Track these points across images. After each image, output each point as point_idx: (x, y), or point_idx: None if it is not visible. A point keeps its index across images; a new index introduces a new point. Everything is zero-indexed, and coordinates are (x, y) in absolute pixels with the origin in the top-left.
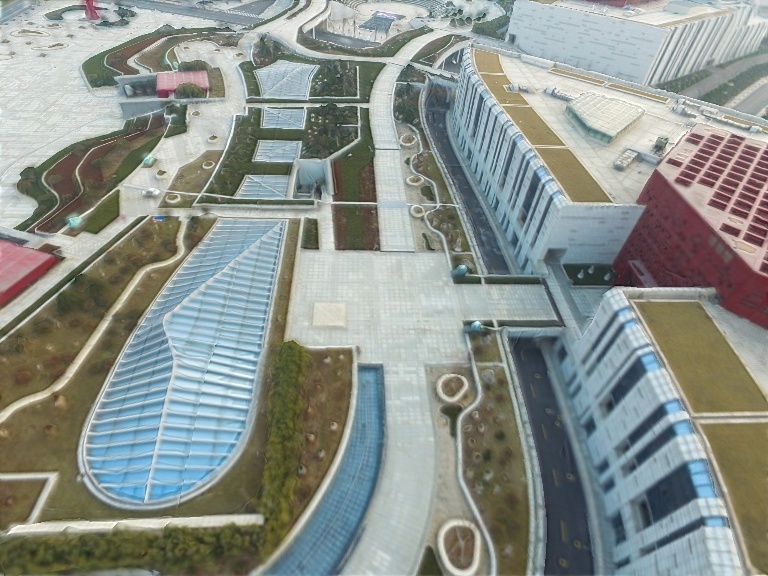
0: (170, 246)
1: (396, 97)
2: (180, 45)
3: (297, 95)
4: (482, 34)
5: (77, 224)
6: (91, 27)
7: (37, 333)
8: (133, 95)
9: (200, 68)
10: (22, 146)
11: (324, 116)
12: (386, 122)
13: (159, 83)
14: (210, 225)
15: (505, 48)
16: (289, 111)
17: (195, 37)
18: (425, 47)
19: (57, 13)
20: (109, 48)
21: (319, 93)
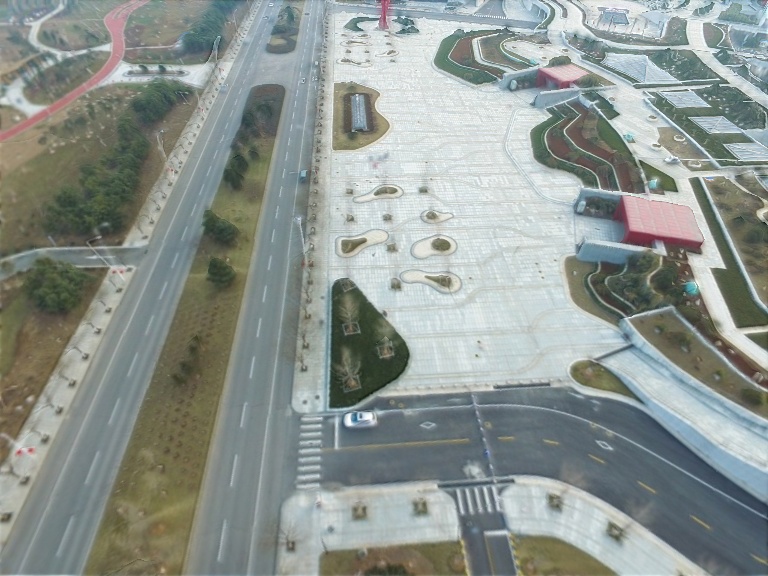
0: (758, 197)
1: (743, 77)
2: (506, 45)
3: (669, 80)
4: (733, 21)
5: (655, 185)
6: (393, 35)
7: (762, 258)
8: (516, 89)
9: (568, 62)
10: (490, 133)
11: (717, 95)
12: (764, 98)
13: (556, 76)
14: (756, 181)
15: (764, 32)
16: (680, 93)
17: (499, 38)
18: (706, 34)
19: (352, 25)
20: (432, 52)
21: (687, 77)
